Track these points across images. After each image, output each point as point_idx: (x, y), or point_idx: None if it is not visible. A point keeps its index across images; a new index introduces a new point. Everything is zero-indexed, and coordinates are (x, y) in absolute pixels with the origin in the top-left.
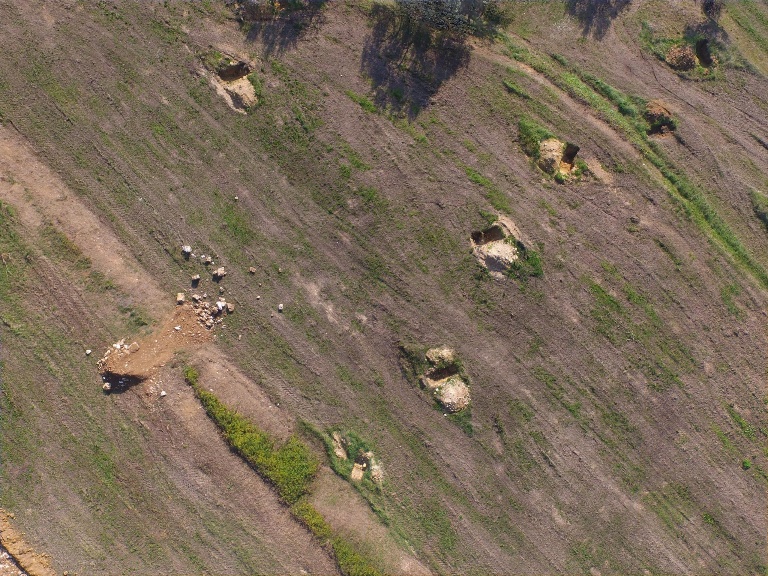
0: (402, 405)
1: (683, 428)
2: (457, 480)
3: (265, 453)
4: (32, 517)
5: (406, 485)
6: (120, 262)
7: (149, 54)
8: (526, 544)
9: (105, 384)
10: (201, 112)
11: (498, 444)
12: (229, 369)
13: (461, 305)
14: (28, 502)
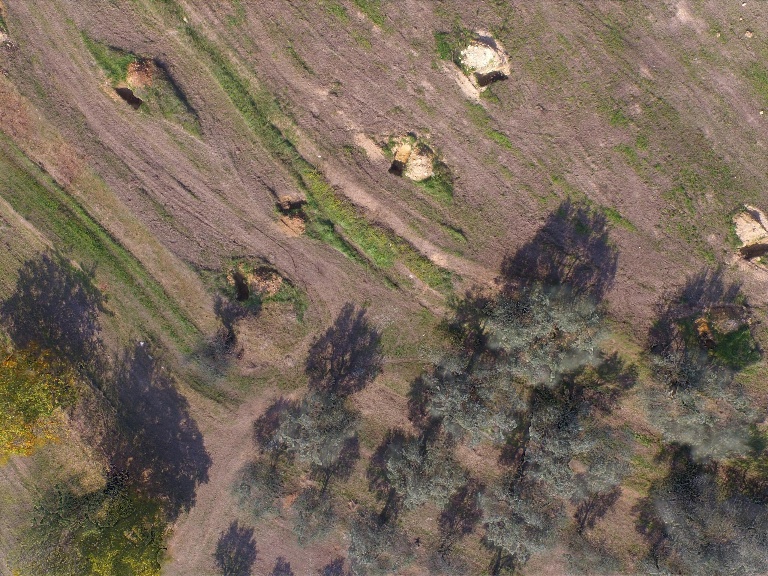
0: None
1: None
2: None
3: None
4: None
5: None
6: None
7: None
8: None
9: None
10: None
11: None
12: None
13: (524, 1)
14: None
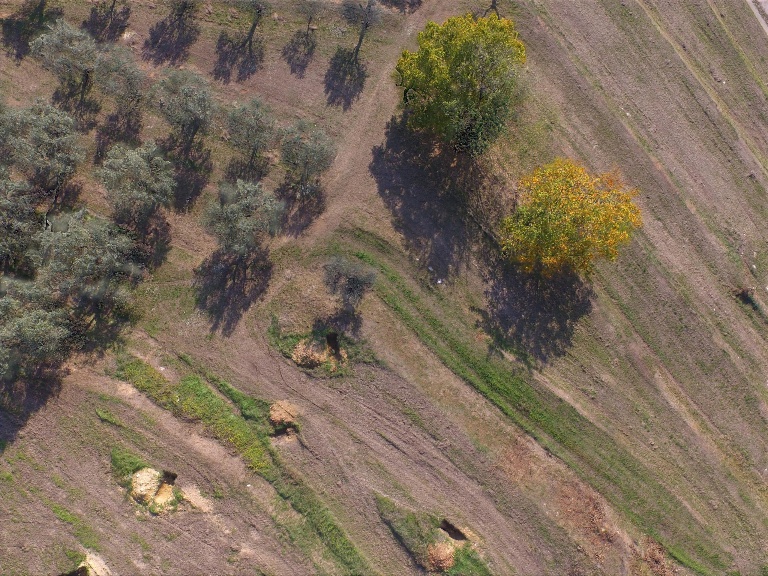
0: None
1: None
2: None
3: None
4: None
5: None
6: None
7: None
8: None
9: None
10: None
11: None
12: None
13: None
14: None
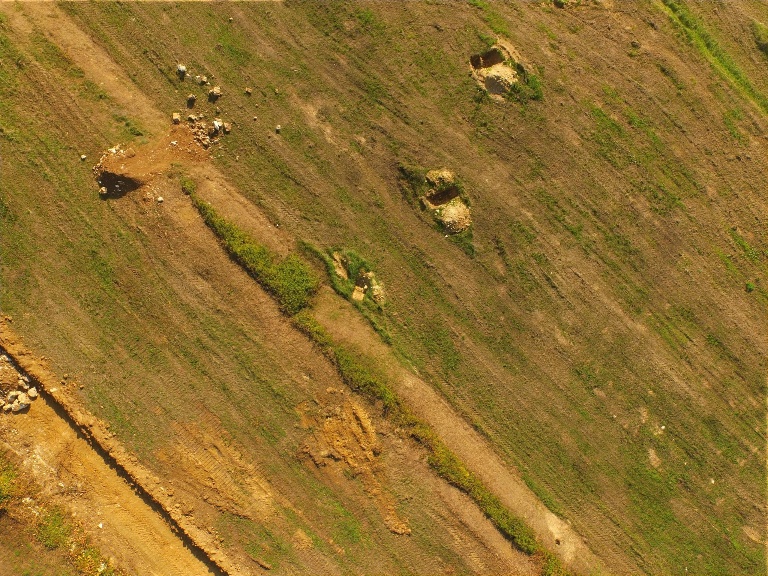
0: (403, 226)
1: (686, 251)
2: (459, 301)
3: (265, 262)
4: (30, 321)
5: (408, 305)
6: (114, 79)
7: None
8: (529, 364)
9: (101, 188)
10: None
11: (500, 265)
12: (227, 188)
13: (461, 128)
14: (26, 306)
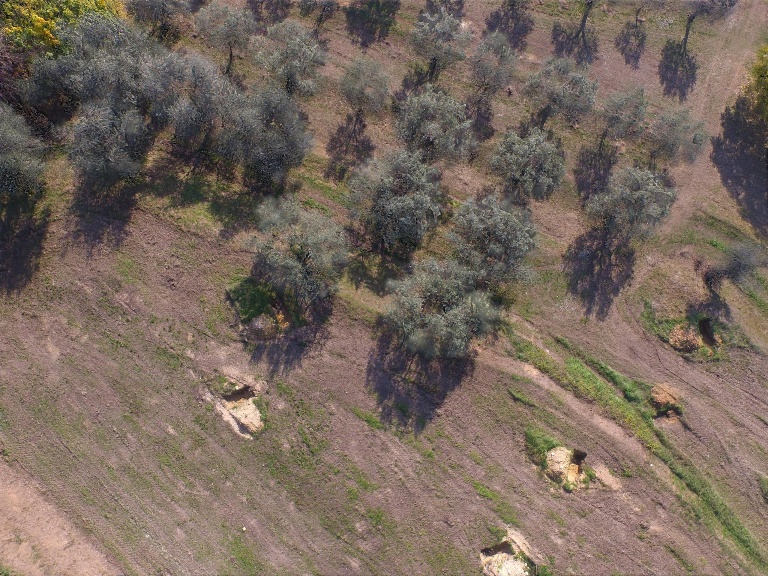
0: None
1: None
2: None
3: None
4: None
5: None
6: None
7: (154, 382)
8: None
9: None
10: (207, 439)
11: None
12: None
13: None
14: None
